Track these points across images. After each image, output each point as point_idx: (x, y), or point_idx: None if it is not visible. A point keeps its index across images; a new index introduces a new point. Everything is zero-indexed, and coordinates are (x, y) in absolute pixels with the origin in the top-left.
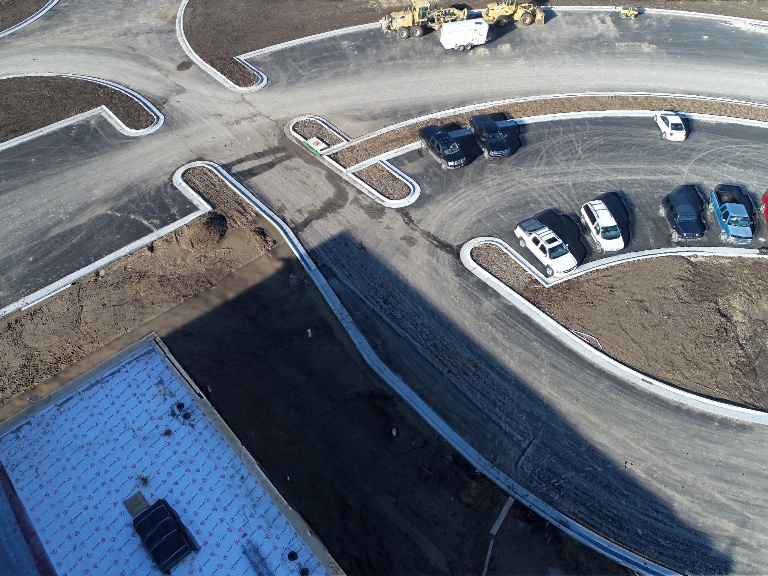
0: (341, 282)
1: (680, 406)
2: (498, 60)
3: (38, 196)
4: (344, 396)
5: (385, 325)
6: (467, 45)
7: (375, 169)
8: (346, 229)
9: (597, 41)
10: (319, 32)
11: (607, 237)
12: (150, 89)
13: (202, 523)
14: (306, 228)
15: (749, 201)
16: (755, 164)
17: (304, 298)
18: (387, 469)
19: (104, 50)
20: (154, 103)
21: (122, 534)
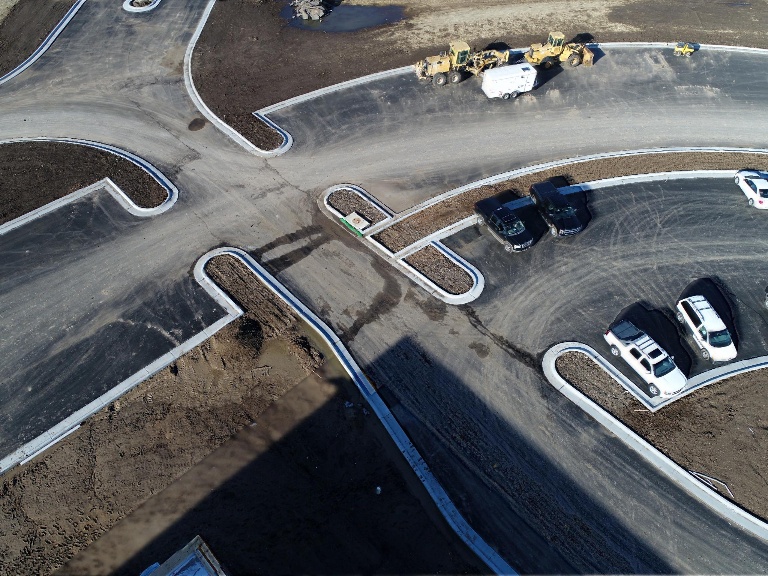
0: (407, 411)
1: None
2: (548, 110)
3: (35, 300)
4: None
5: (467, 471)
6: (513, 93)
7: (428, 253)
8: (404, 335)
9: (654, 84)
10: (345, 79)
11: (716, 344)
12: (160, 155)
13: None
14: (357, 335)
15: None
16: None
17: (365, 435)
18: None
19: (104, 106)
20: (165, 173)
21: None
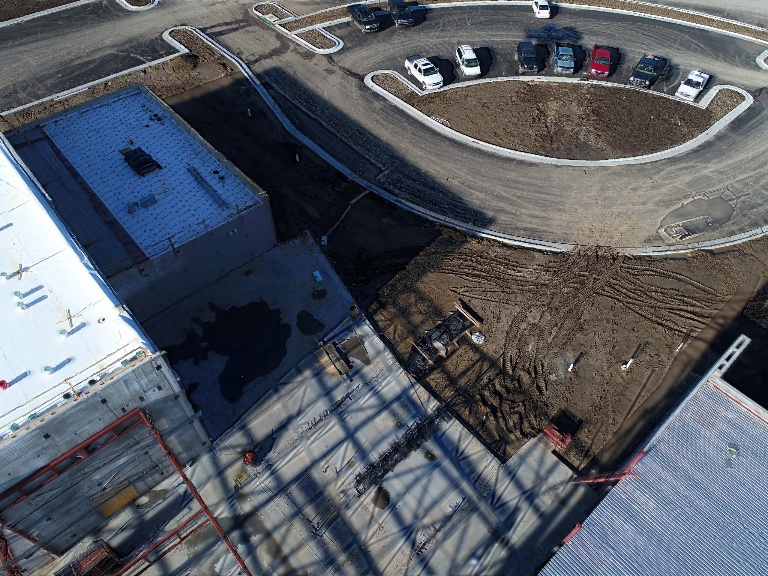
0: (276, 91)
1: (494, 154)
2: None
3: (64, 43)
4: (268, 144)
5: (303, 113)
6: None
7: (312, 32)
8: (285, 65)
9: None
10: None
11: (469, 66)
12: None
13: (164, 160)
14: (256, 63)
15: (585, 53)
16: (599, 33)
17: (249, 99)
18: (290, 175)
19: None
20: None
21: (117, 162)
